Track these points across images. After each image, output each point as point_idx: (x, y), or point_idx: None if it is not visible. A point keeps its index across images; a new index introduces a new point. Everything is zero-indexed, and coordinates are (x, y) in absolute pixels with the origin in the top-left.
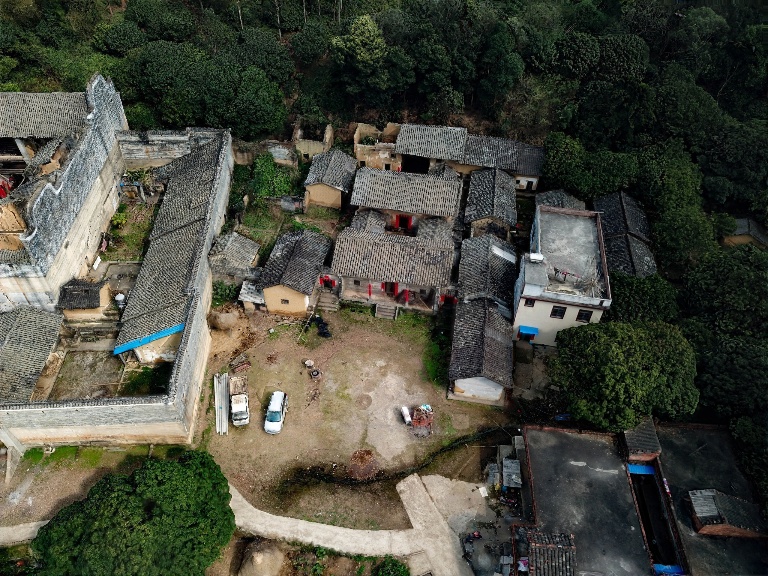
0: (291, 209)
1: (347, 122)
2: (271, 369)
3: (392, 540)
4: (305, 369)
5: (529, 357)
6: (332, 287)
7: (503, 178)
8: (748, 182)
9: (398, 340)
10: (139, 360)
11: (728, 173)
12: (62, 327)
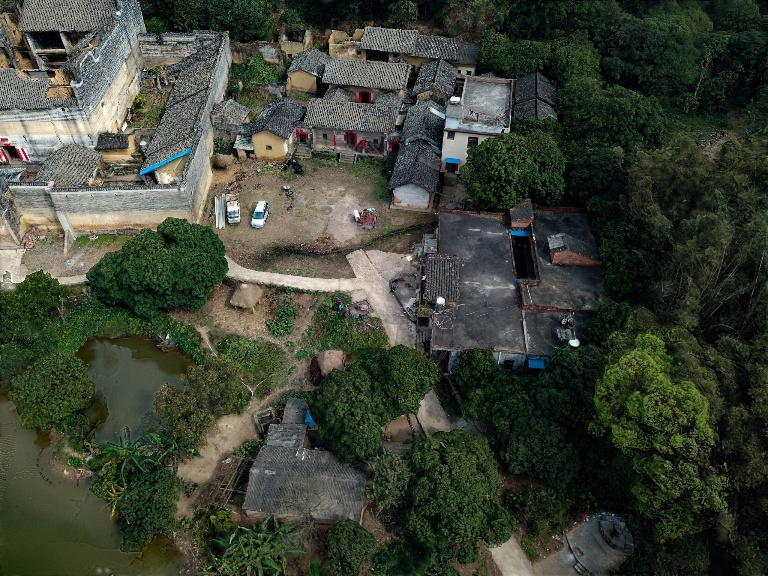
0: (277, 93)
1: (324, 33)
2: (258, 192)
3: (340, 283)
4: (283, 192)
5: (454, 183)
6: (306, 140)
7: (446, 66)
8: (636, 61)
9: (356, 176)
10: (158, 183)
11: (621, 55)
12: (100, 162)
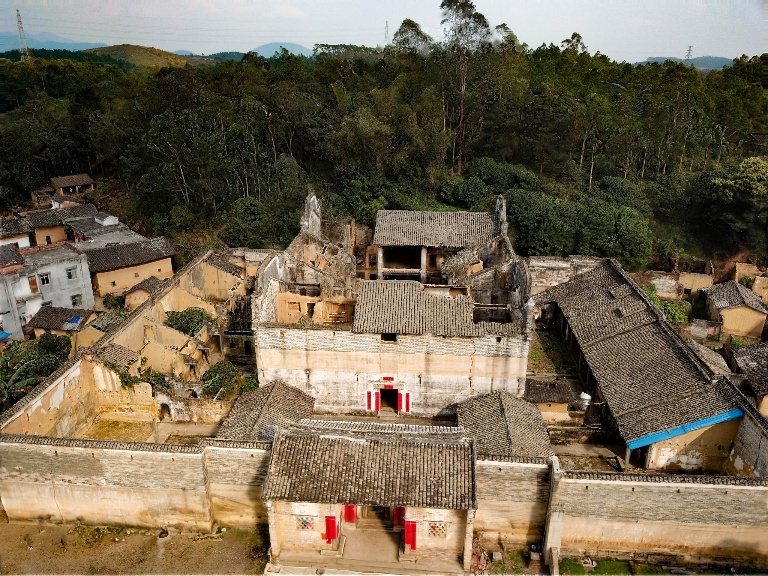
0: (702, 336)
1: None
2: None
3: None
4: None
5: None
6: None
7: None
8: None
9: None
10: (646, 464)
11: None
12: None
